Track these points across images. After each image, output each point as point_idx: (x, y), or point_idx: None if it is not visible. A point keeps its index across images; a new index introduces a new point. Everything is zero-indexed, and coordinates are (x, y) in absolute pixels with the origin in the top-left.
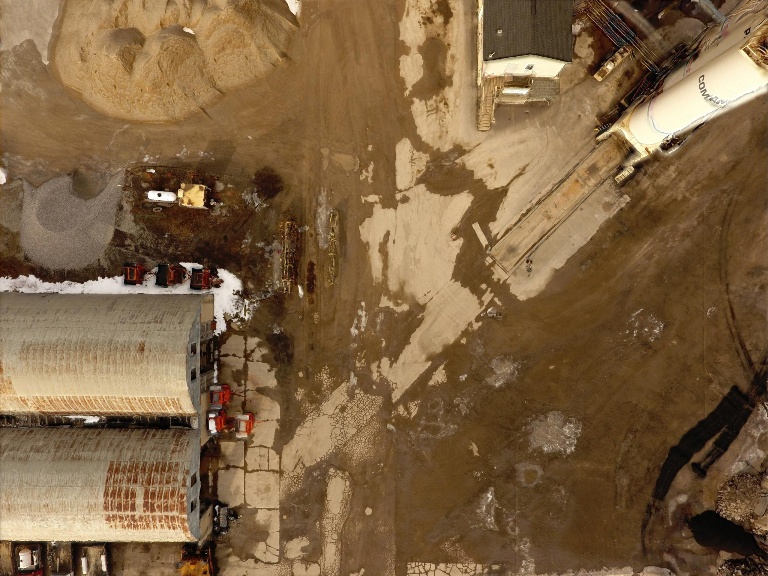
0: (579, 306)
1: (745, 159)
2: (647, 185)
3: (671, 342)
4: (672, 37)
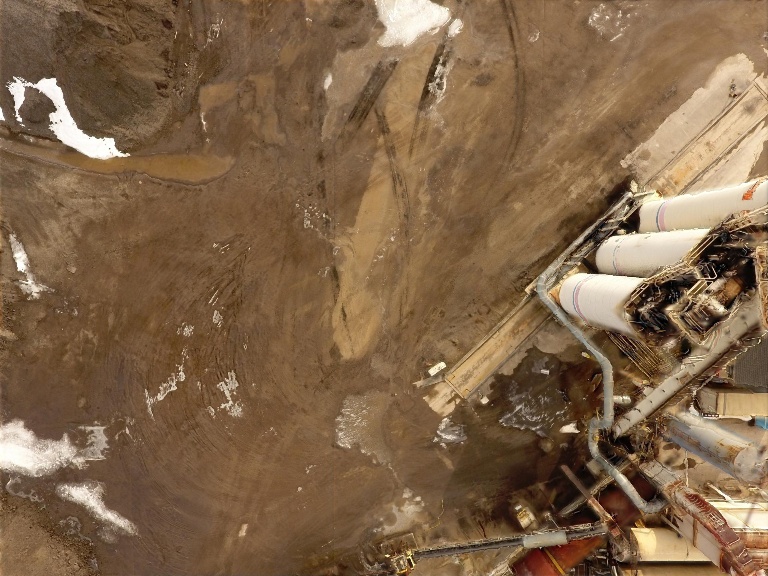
0: (680, 46)
1: (495, 205)
2: (601, 178)
3: (581, 2)
4: (571, 334)
